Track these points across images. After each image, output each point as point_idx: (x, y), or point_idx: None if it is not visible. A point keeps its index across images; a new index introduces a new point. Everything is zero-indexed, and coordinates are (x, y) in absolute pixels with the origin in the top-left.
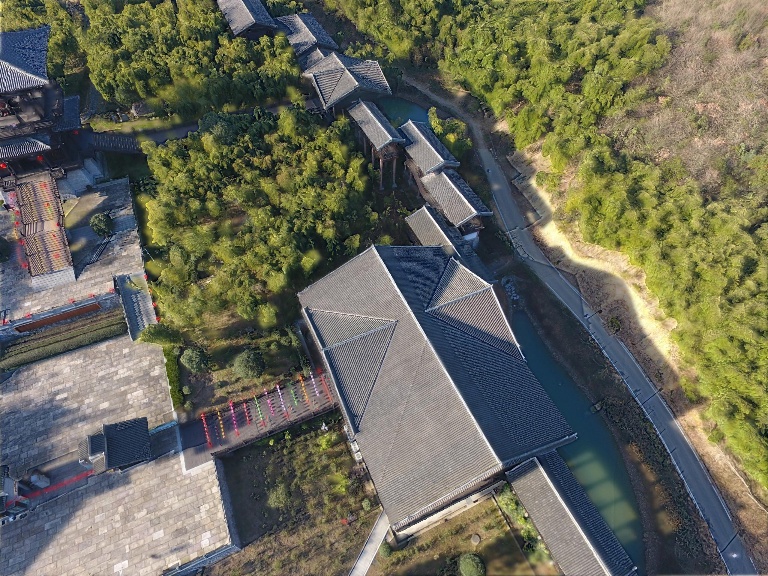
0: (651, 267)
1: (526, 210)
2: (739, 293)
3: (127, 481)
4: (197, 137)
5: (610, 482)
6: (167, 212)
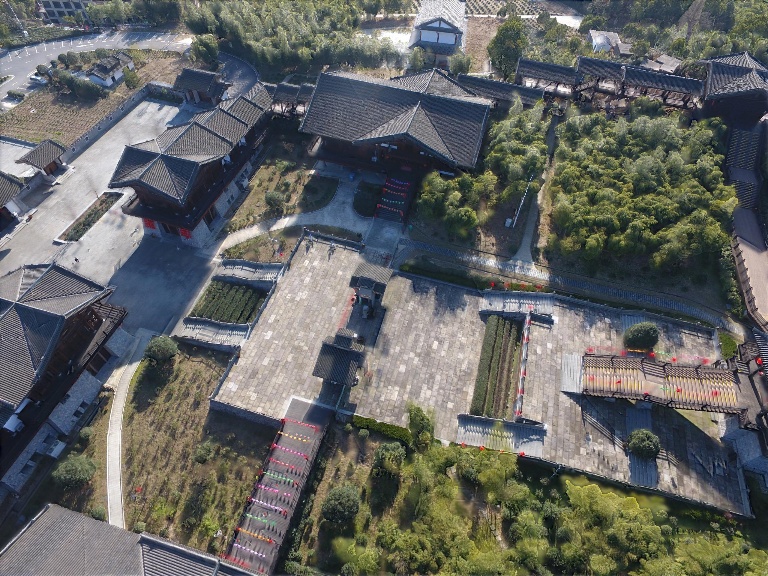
0: None
1: None
2: None
3: None
4: None
5: None
6: None
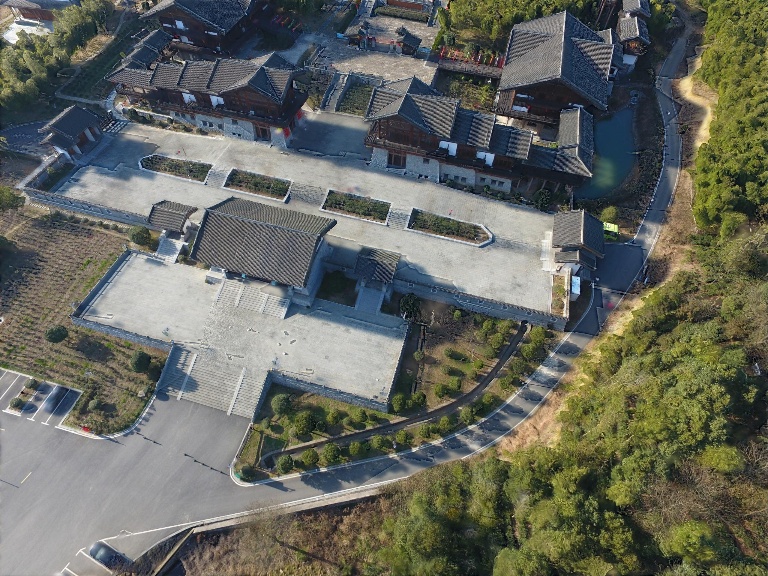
0: (726, 89)
1: (682, 72)
2: (766, 104)
3: (402, 58)
4: None
5: (615, 174)
6: None
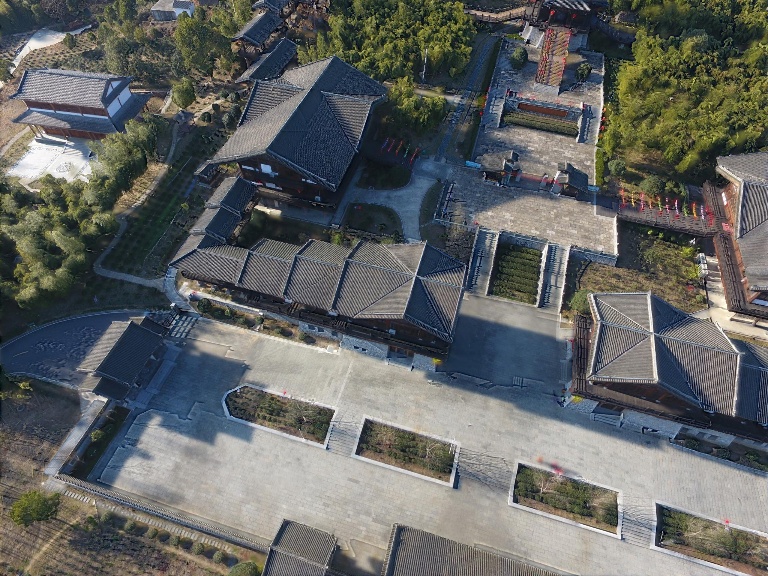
0: None
1: None
2: None
3: (561, 201)
4: (677, 41)
5: None
6: (639, 77)
